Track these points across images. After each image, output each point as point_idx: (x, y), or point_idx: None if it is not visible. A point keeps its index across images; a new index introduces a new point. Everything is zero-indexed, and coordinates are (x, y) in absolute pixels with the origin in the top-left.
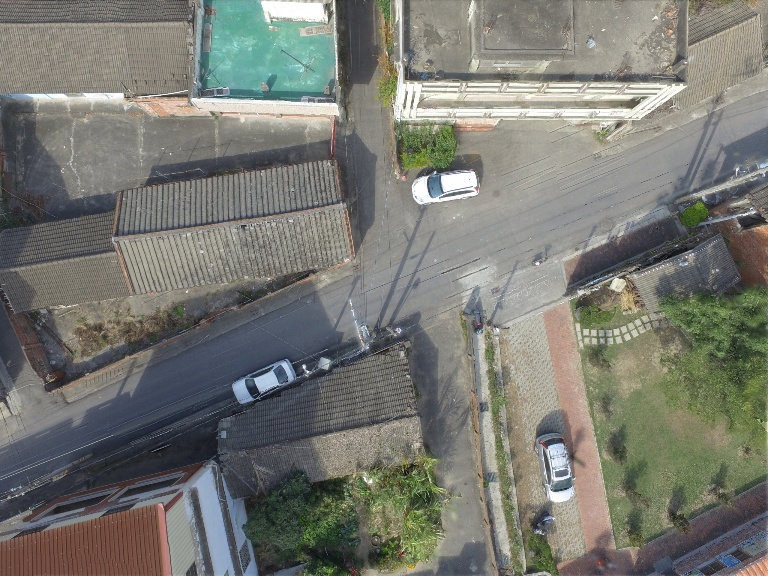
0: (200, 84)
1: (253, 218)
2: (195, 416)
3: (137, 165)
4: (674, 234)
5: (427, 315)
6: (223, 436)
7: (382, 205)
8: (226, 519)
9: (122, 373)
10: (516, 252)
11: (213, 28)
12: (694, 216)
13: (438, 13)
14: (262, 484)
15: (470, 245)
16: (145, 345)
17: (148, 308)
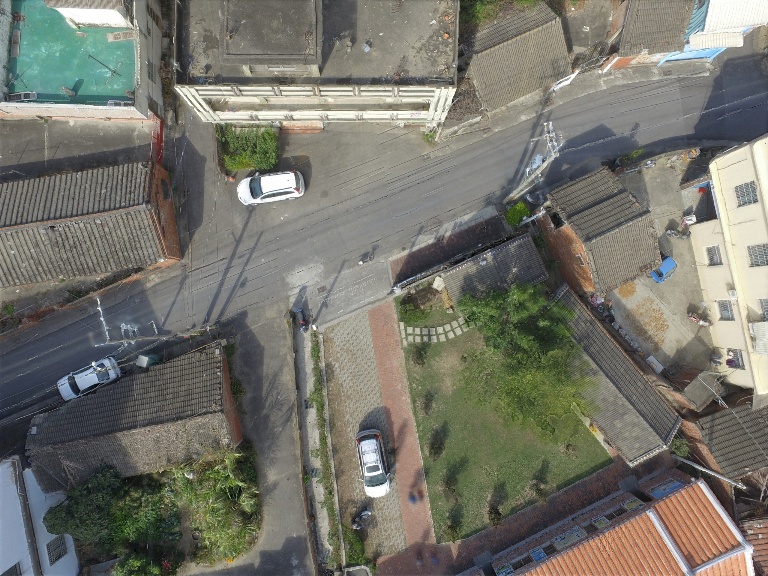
0: (6, 89)
1: (59, 219)
2: (23, 413)
3: None
4: (501, 234)
5: (254, 314)
6: (33, 432)
7: (211, 206)
8: (25, 513)
9: None
10: (343, 252)
11: (22, 34)
12: (514, 216)
13: None
14: (72, 479)
15: (297, 245)
16: None
17: None
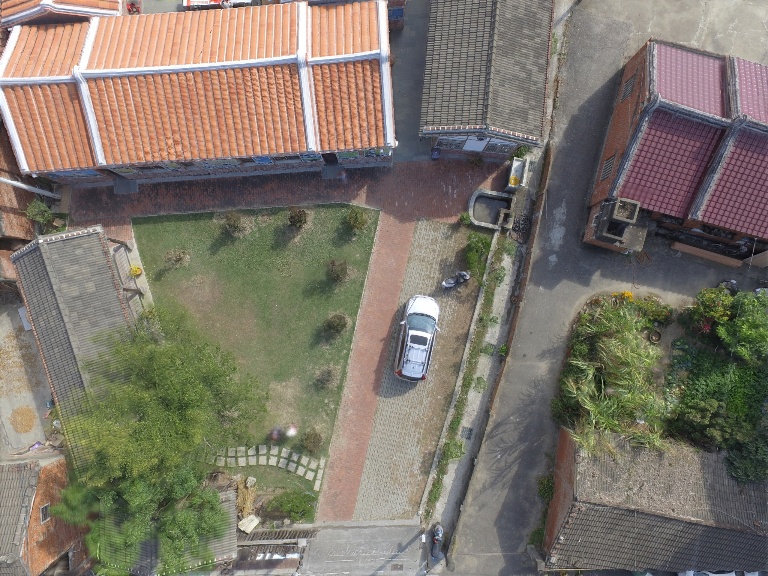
0: None
1: None
2: None
3: None
4: None
5: (491, 570)
6: None
7: None
8: None
9: None
10: None
11: None
12: (118, 575)
13: None
14: None
15: None
16: None
17: None
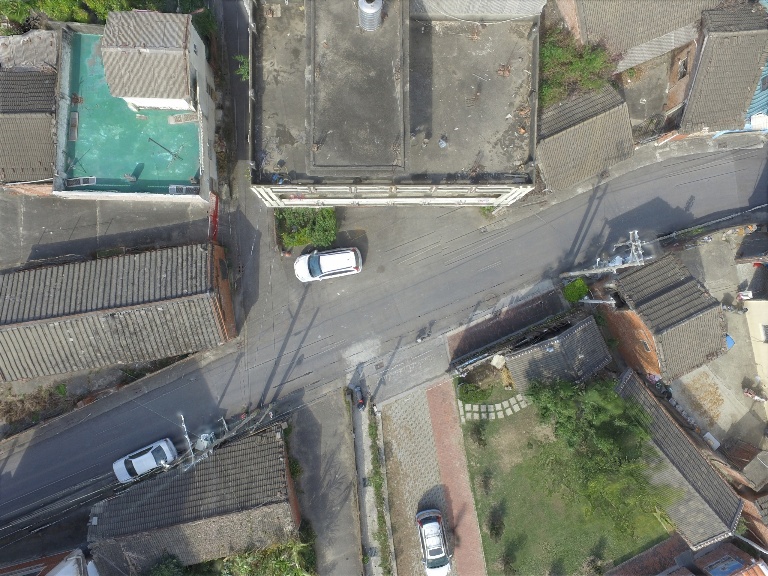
0: (65, 174)
1: (120, 307)
2: (77, 495)
3: (17, 244)
4: (558, 308)
5: (311, 391)
6: (94, 523)
7: (266, 282)
8: None
9: (3, 452)
10: (400, 327)
11: (80, 116)
12: (573, 293)
13: (290, 113)
14: (134, 569)
15: (354, 321)
16: (27, 424)
17: (30, 387)
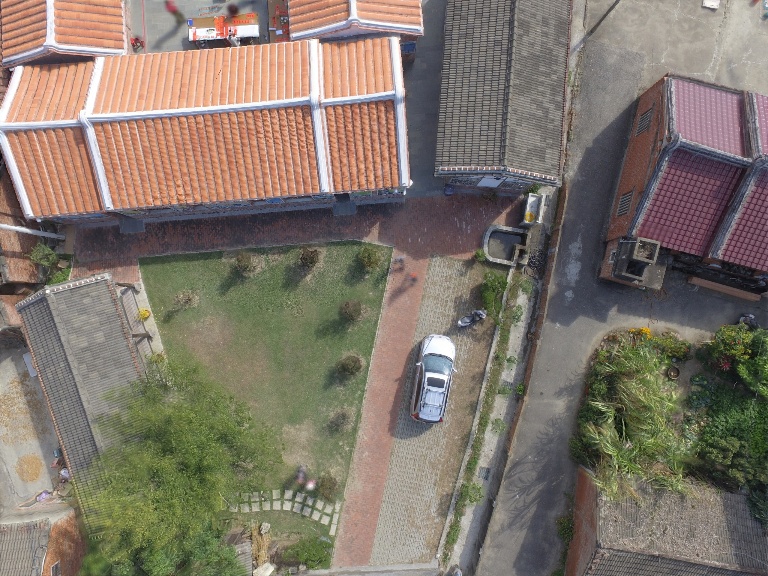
0: None
1: None
2: None
3: None
4: None
5: None
6: None
7: None
8: None
9: None
10: None
11: None
12: None
13: None
14: None
15: None
16: None
17: None
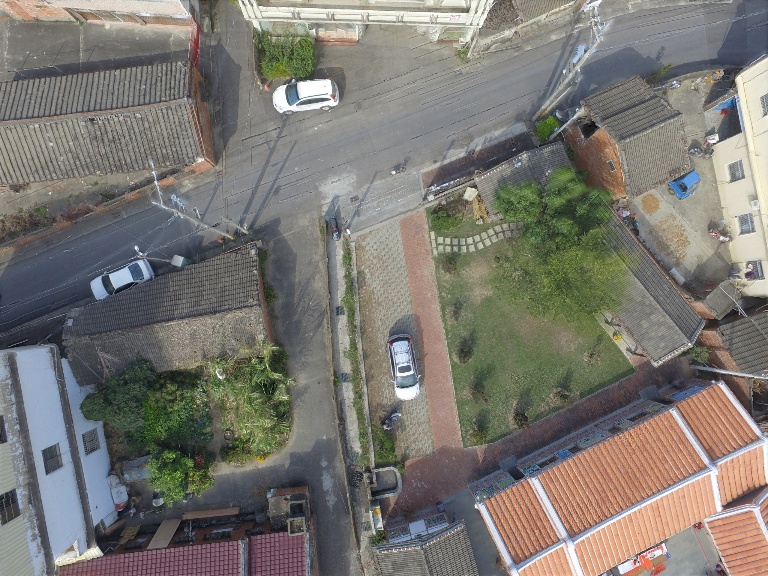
0: None
1: (99, 111)
2: (55, 313)
3: (2, 68)
4: None
5: (287, 221)
6: (69, 324)
7: (245, 114)
8: (63, 398)
9: None
10: (376, 163)
11: None
12: (544, 129)
13: None
14: (108, 371)
15: (331, 155)
16: None
17: (11, 208)
